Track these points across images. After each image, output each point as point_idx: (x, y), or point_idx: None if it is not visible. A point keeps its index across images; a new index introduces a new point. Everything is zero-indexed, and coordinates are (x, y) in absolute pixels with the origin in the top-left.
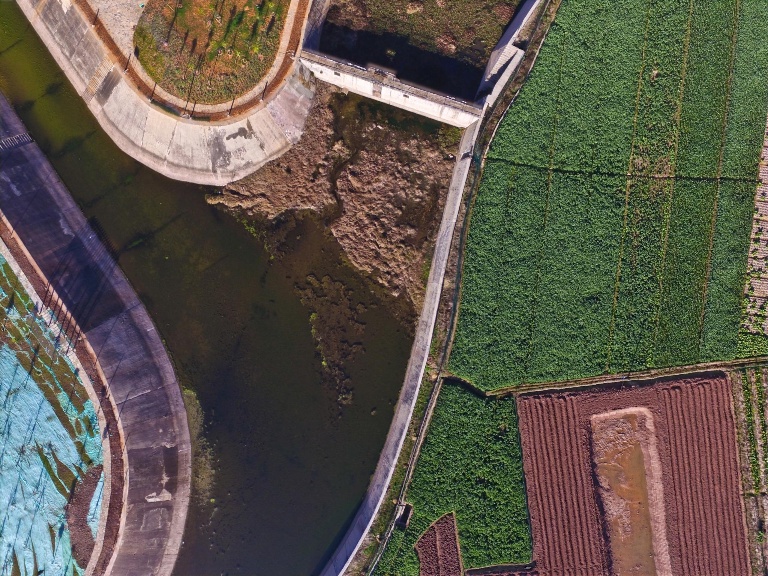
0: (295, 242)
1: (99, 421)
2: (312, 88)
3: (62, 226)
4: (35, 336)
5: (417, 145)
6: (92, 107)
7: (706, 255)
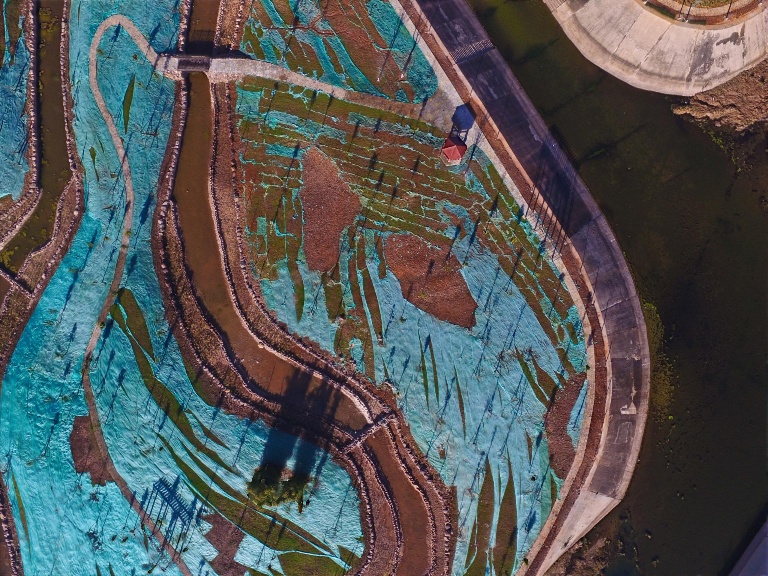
0: (762, 155)
1: (584, 328)
2: None
3: (532, 132)
4: (518, 240)
5: None
6: (558, 14)
7: None
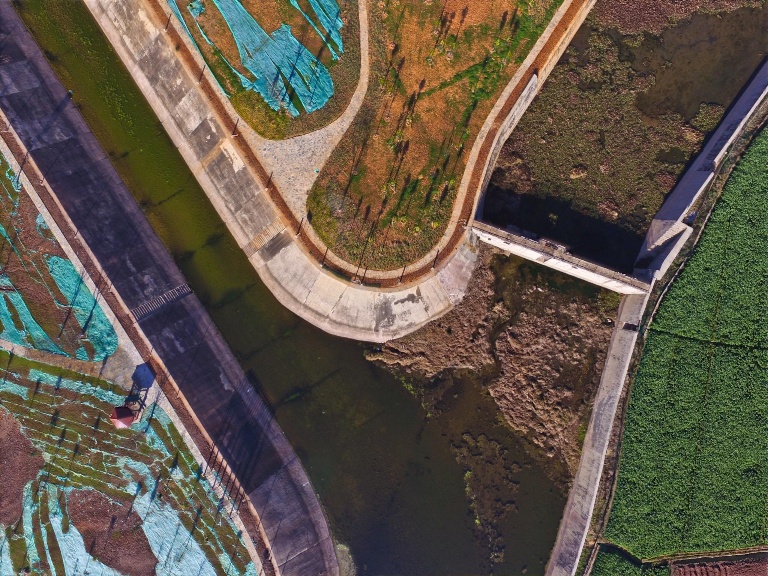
0: (452, 400)
1: None
2: (477, 251)
3: (222, 381)
4: (198, 497)
5: (576, 308)
6: (253, 261)
7: None
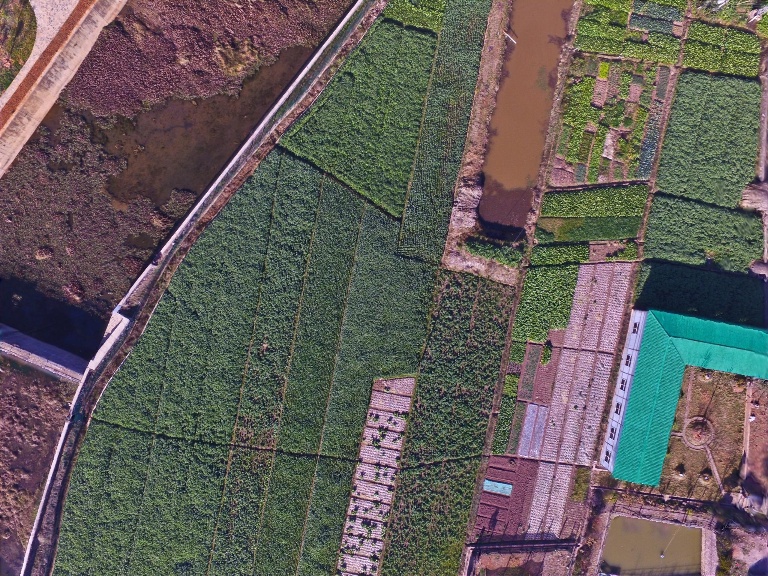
0: None
1: None
2: None
3: None
4: None
5: (37, 391)
6: None
7: (301, 529)
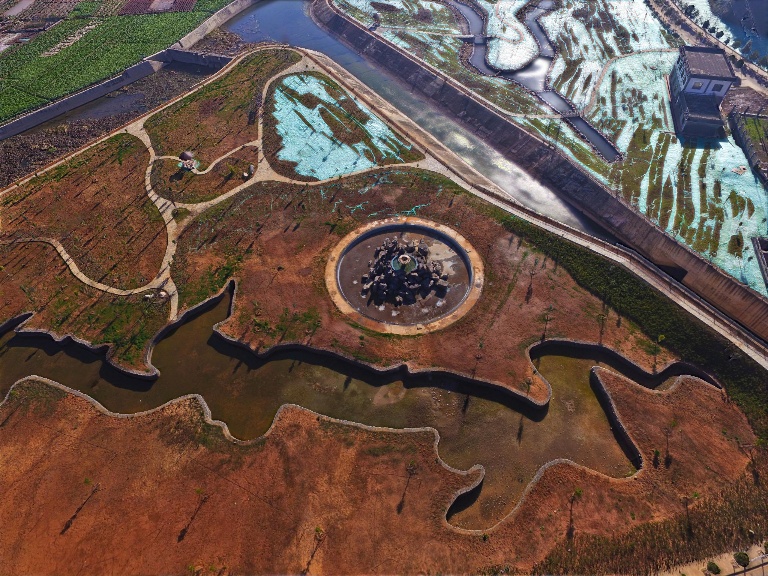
0: None
1: (334, 2)
2: None
3: None
4: None
5: None
6: None
7: None
